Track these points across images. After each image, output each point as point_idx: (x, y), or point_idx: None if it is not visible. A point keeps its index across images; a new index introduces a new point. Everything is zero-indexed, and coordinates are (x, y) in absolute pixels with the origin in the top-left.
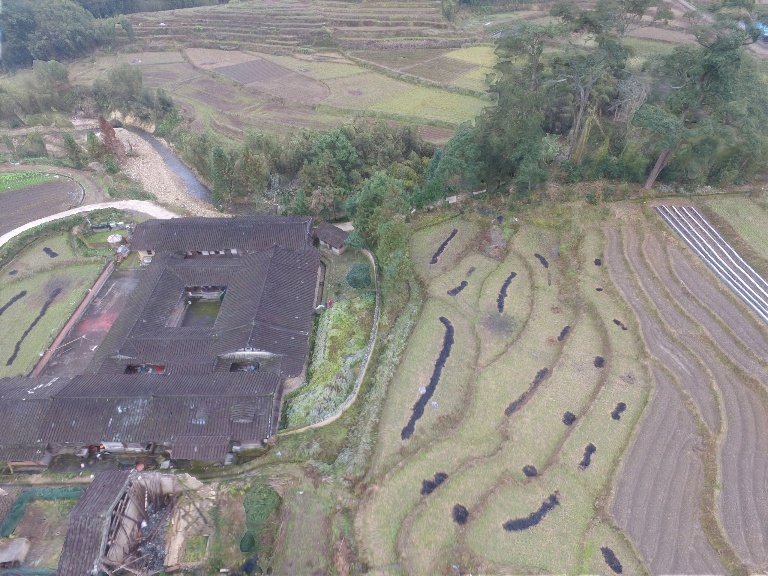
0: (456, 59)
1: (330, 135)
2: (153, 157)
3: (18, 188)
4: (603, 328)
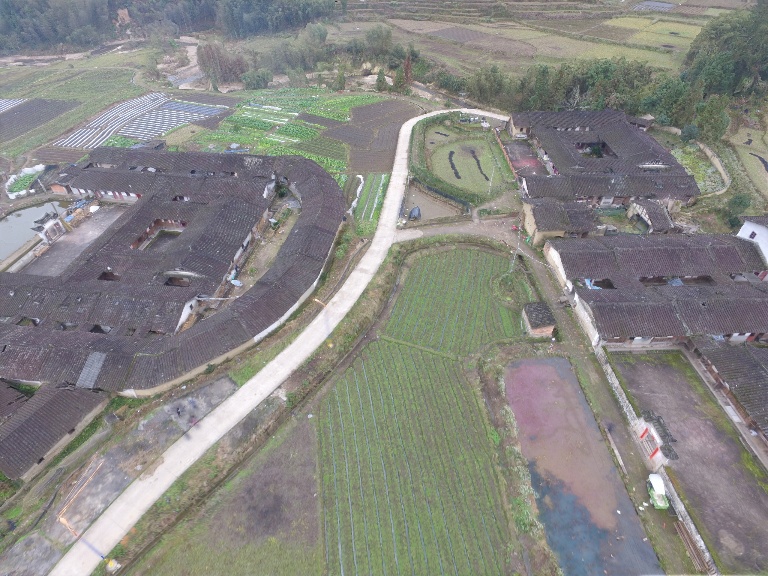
0: (616, 26)
1: (602, 63)
2: (422, 92)
3: (368, 104)
4: None
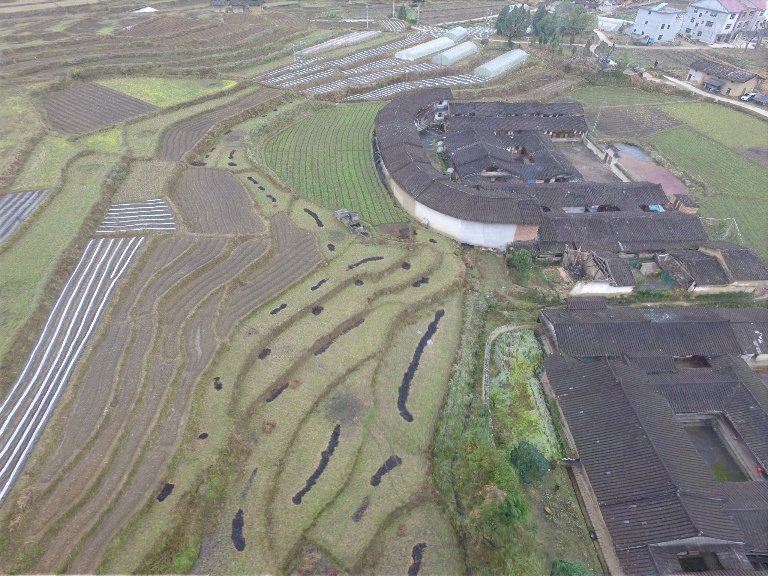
0: None
1: None
2: None
3: None
4: (239, 382)
